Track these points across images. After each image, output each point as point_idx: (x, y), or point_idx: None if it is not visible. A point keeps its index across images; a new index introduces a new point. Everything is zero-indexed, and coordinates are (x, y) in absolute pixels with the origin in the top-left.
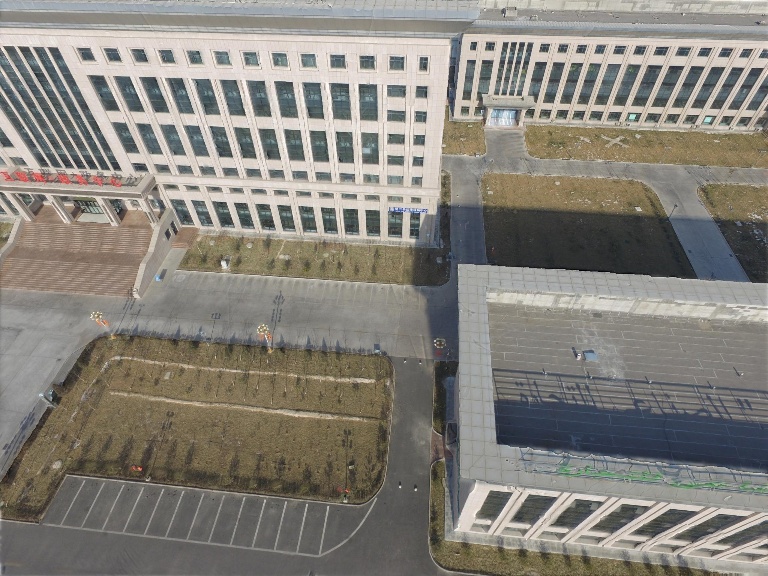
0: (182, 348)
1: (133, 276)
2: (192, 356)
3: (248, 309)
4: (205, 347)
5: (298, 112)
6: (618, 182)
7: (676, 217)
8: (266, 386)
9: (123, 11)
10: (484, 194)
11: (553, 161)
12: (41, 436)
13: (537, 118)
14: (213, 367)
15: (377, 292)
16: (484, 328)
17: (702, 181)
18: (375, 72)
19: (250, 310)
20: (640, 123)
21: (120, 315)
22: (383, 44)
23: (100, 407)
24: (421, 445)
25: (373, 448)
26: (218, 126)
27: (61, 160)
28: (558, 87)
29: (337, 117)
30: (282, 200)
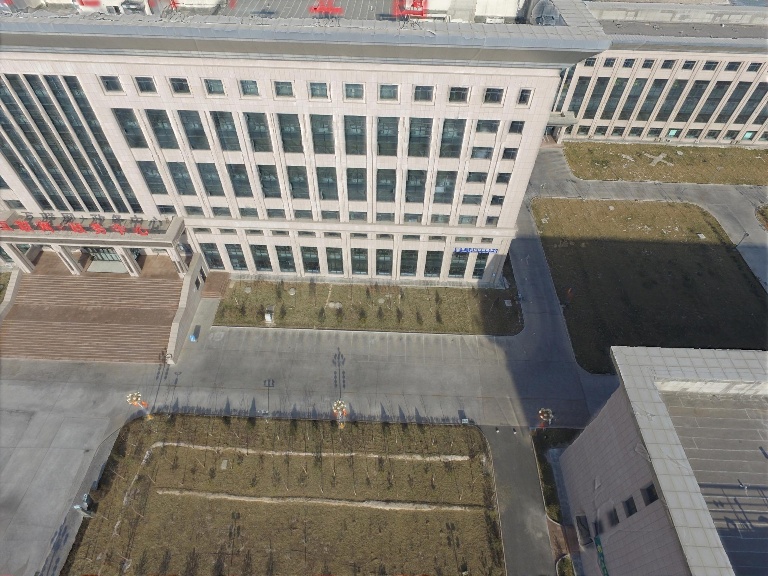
0: (236, 427)
1: (164, 338)
2: (250, 437)
3: (305, 373)
4: (263, 425)
5: (367, 149)
6: (673, 205)
7: (742, 244)
8: (344, 472)
9: (170, 35)
10: (538, 222)
11: (601, 183)
12: (80, 558)
13: (575, 134)
14: (278, 450)
15: (448, 345)
16: (673, 437)
17: (757, 203)
18: (466, 105)
19: (308, 374)
20: (680, 139)
21: (154, 387)
22: (482, 75)
23: (148, 512)
24: (539, 538)
25: (484, 546)
26: (268, 164)
27: (68, 202)
28: (600, 102)
29: (412, 154)
30: (333, 242)
